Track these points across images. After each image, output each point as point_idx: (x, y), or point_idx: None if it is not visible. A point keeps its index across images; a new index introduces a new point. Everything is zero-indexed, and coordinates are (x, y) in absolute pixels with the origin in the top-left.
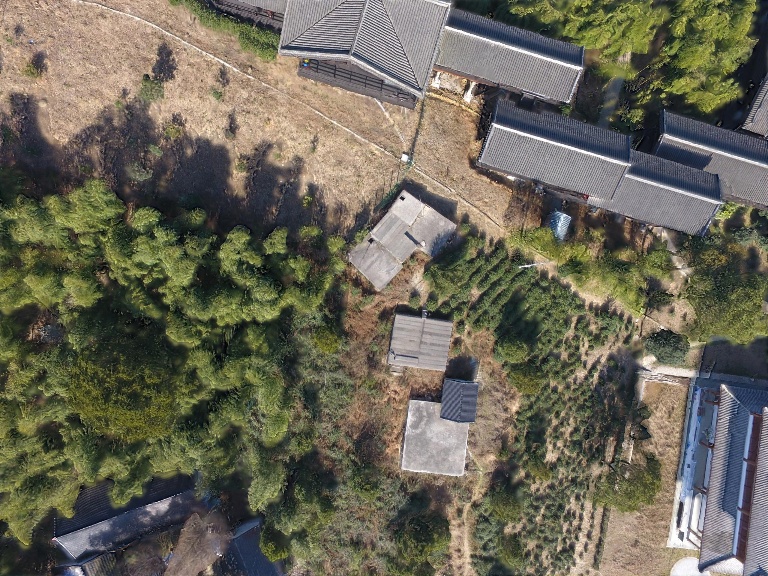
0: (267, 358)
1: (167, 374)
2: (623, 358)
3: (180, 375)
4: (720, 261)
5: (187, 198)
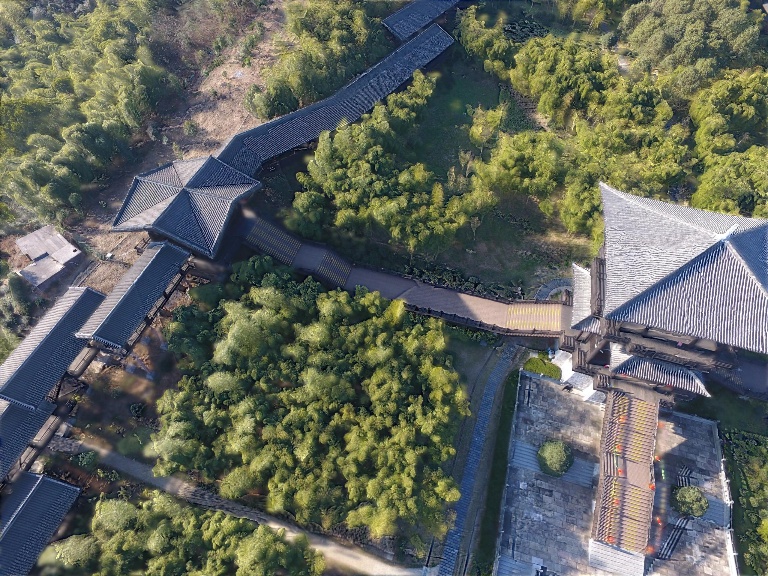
0: (4, 184)
1: (17, 136)
2: None
3: (22, 149)
4: None
5: (118, 143)
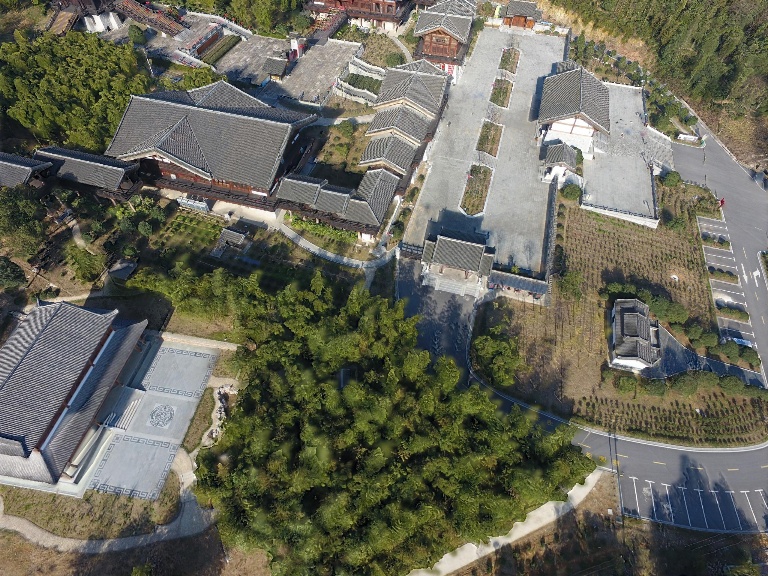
0: None
1: None
2: (4, 302)
3: None
4: (2, 189)
5: None
